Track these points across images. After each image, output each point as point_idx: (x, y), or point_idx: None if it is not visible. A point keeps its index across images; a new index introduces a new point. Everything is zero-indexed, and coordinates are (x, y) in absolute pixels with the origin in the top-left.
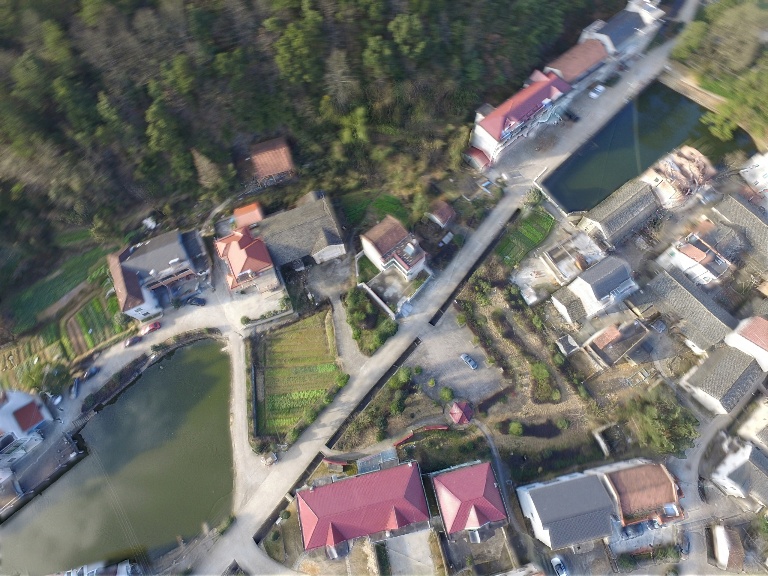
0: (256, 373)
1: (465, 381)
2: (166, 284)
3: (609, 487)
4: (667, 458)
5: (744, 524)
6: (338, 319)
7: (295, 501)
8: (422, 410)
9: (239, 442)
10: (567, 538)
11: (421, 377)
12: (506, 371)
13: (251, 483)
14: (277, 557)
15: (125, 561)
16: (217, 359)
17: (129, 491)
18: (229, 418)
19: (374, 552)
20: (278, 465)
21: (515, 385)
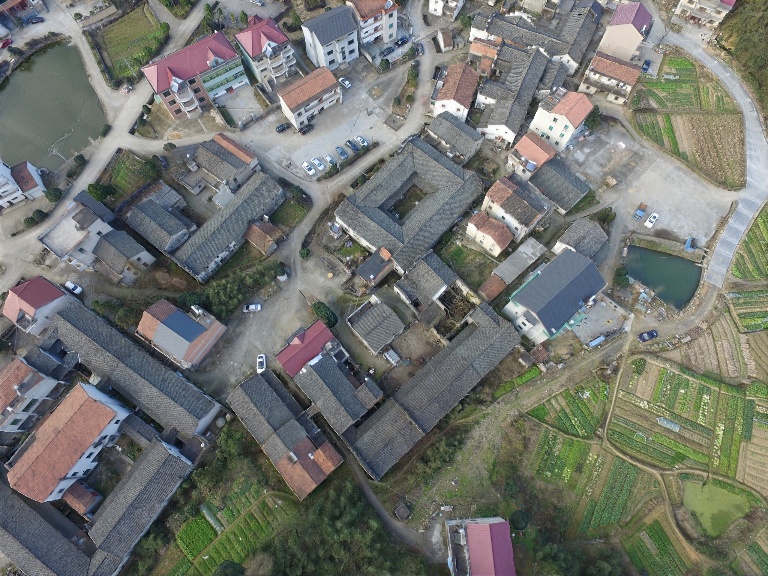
0: (101, 52)
1: (257, 14)
2: (5, 9)
3: (348, 4)
4: (401, 12)
5: (454, 28)
6: (153, 6)
7: (154, 107)
8: (231, 37)
9: (100, 88)
10: (328, 35)
11: (225, 21)
12: (284, 0)
13: (117, 106)
14: (150, 136)
15: (34, 167)
16: (66, 52)
17: (19, 117)
18: (88, 79)
19: (217, 109)
20: (134, 92)
21: (292, 6)
